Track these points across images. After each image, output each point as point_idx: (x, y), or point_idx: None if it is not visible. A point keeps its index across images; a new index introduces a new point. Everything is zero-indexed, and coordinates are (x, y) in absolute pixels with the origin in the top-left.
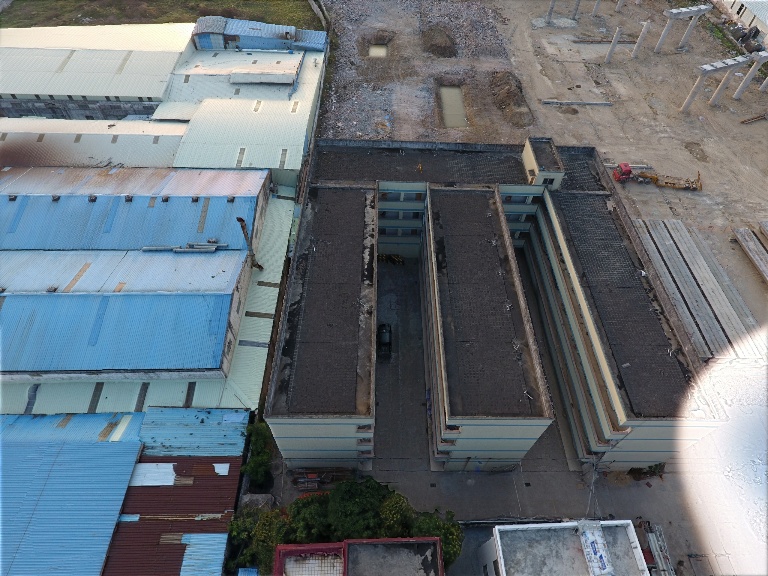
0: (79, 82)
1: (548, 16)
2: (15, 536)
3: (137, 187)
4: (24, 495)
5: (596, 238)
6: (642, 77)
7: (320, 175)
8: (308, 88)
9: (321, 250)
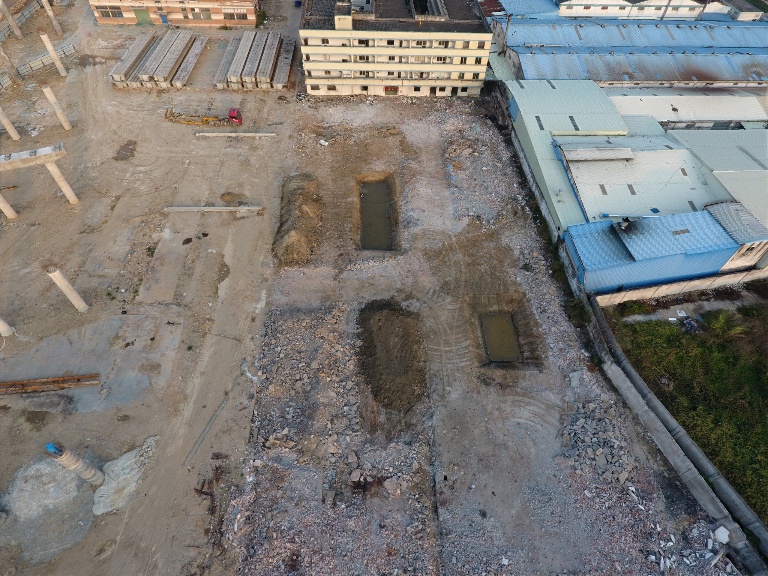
0: (759, 138)
1: (95, 468)
2: (528, 1)
3: (595, 61)
4: (534, 5)
5: (326, 4)
6: (59, 268)
7: (480, 25)
8: (543, 150)
9: (464, 2)
